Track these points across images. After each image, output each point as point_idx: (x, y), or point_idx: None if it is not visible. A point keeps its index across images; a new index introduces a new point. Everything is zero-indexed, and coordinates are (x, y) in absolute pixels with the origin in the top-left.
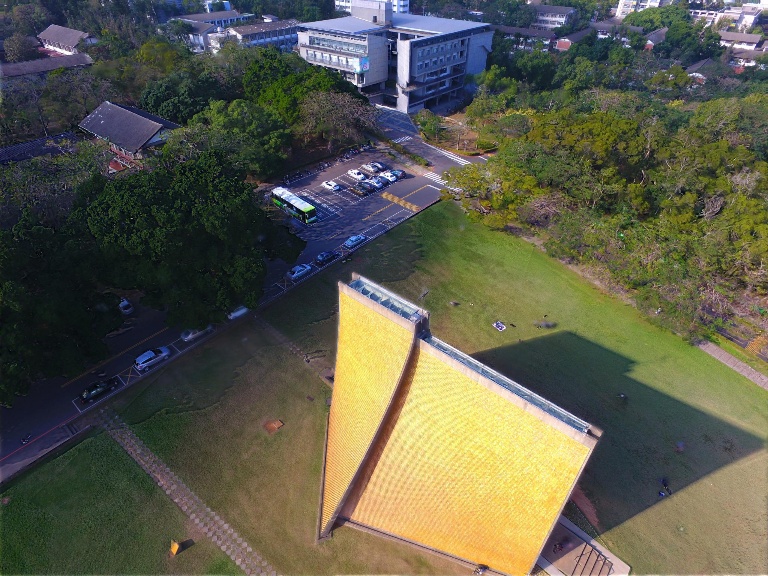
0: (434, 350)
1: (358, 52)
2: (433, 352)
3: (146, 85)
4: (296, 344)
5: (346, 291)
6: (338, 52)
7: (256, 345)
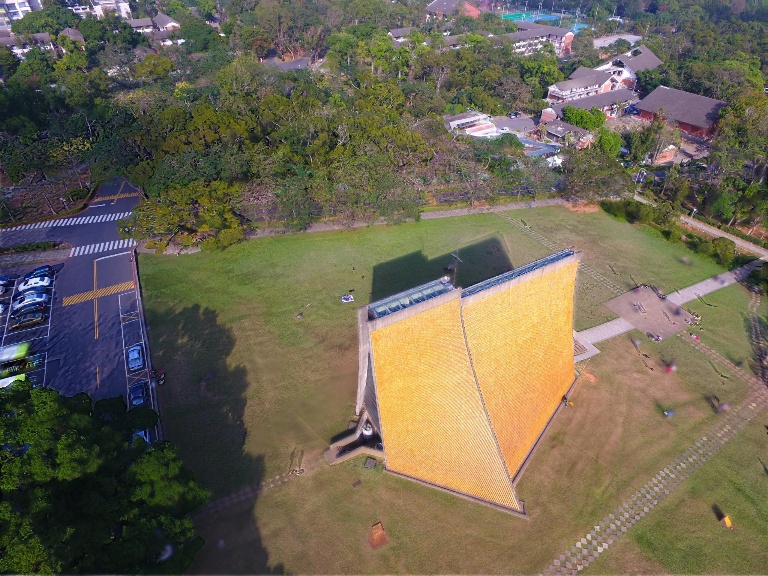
0: (473, 297)
1: None
2: (472, 299)
3: None
4: (267, 478)
5: (380, 325)
6: None
7: (241, 529)
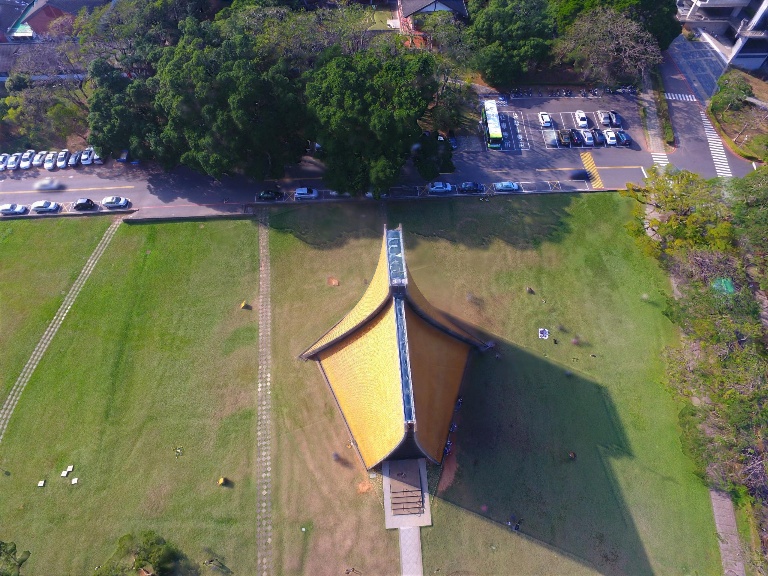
0: (394, 309)
1: None
2: None
3: None
4: None
5: None
6: None
7: (367, 224)
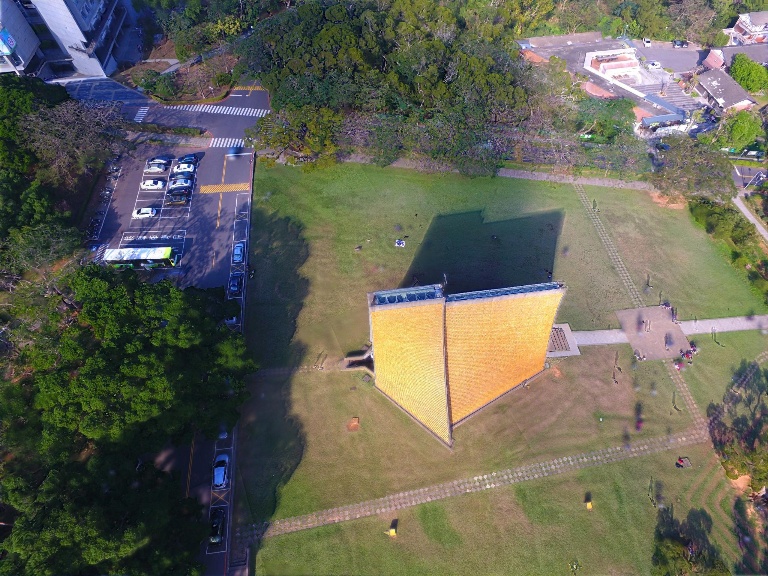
0: (458, 303)
1: None
2: (457, 304)
3: None
4: (300, 365)
5: (378, 309)
6: None
7: (276, 391)
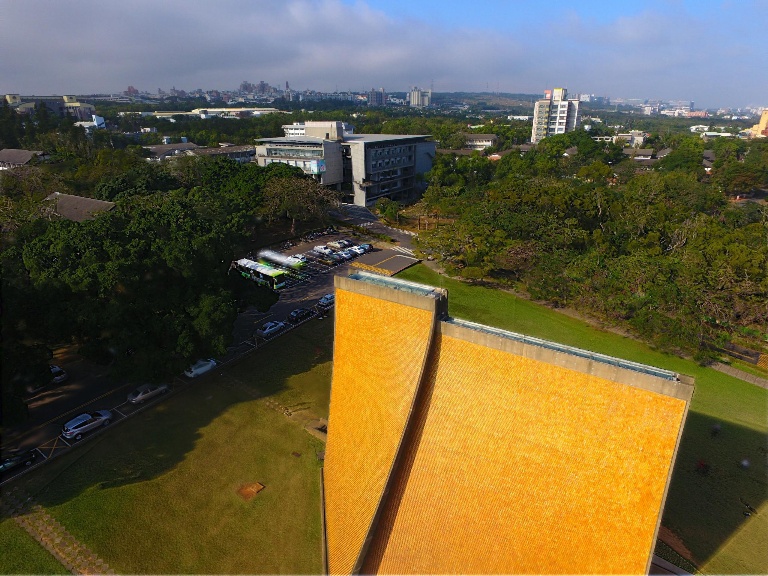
0: (460, 330)
1: None
2: (459, 333)
3: (101, 180)
4: (273, 398)
5: (344, 285)
6: (295, 157)
7: (224, 402)
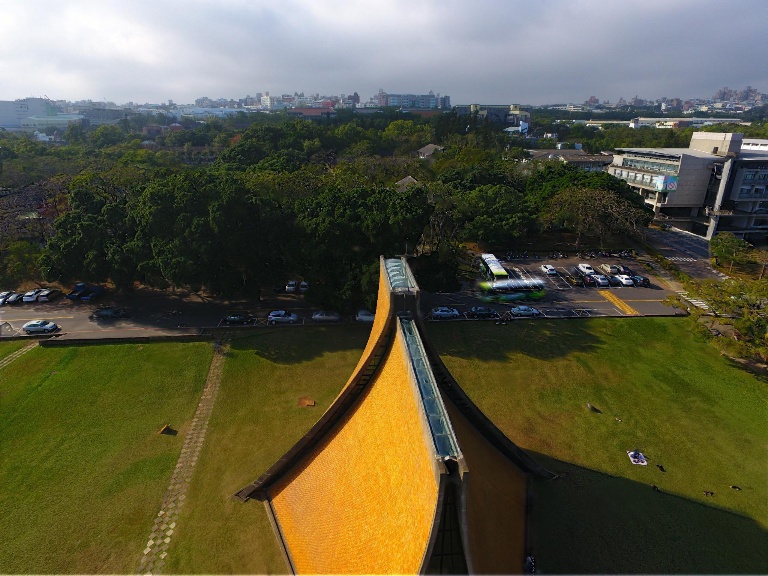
0: (399, 329)
1: (669, 172)
2: (399, 332)
3: (445, 171)
4: None
5: None
6: (645, 170)
7: (356, 345)
